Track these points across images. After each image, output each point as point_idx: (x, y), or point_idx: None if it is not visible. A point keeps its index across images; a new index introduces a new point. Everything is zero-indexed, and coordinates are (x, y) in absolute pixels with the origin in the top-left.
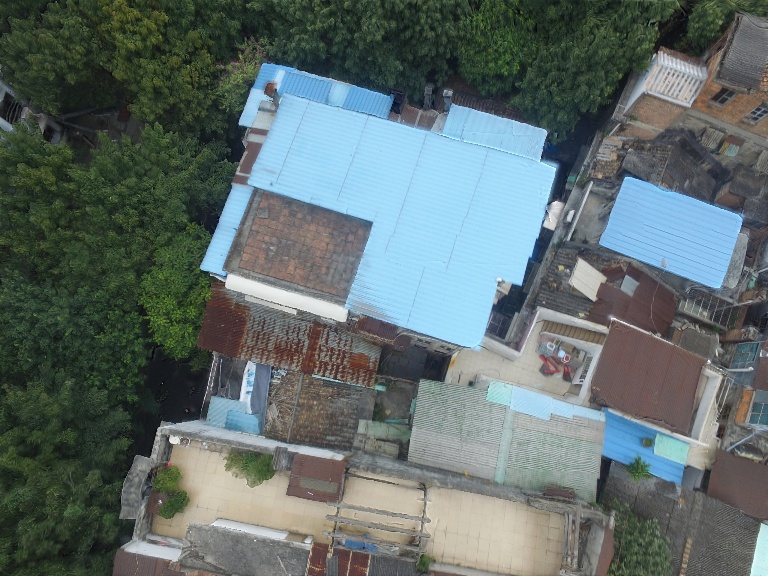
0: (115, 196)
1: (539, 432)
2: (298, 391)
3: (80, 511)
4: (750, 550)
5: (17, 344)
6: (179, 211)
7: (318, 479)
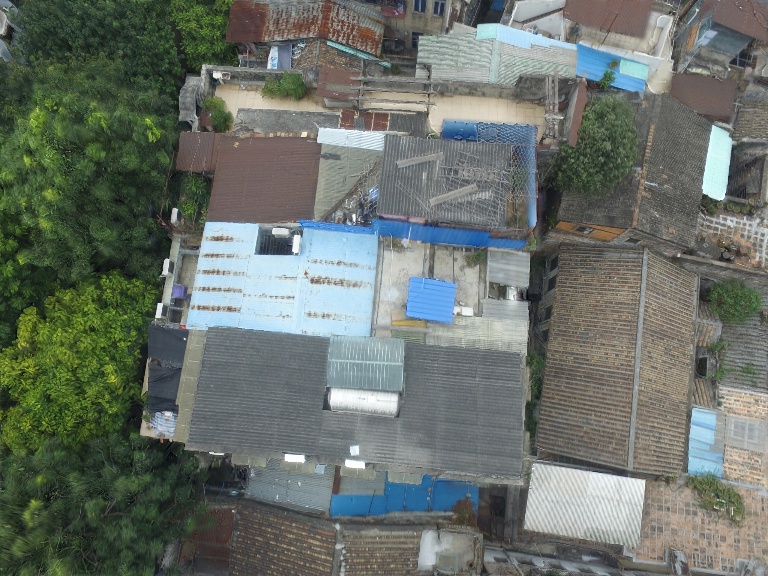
0: None
1: (522, 58)
2: (317, 54)
3: (148, 100)
4: (704, 143)
5: (71, 42)
6: None
7: (341, 85)
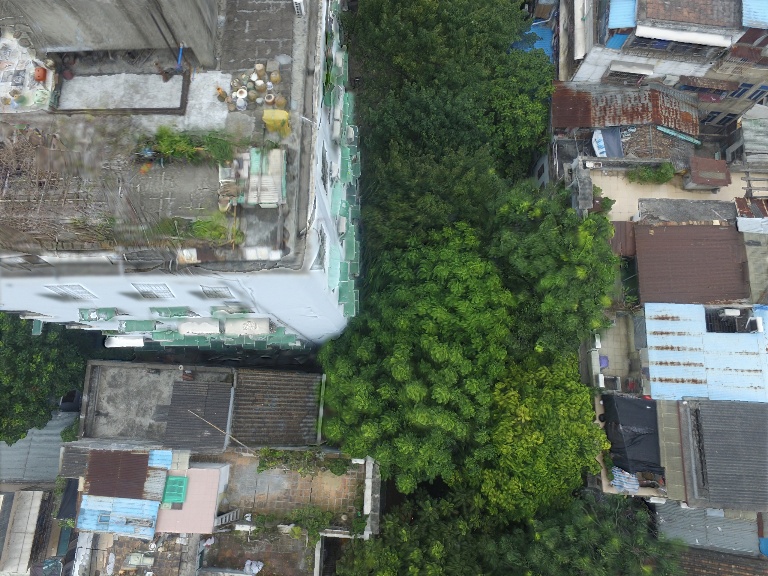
0: (475, 20)
1: None
2: (651, 138)
3: None
4: None
5: (425, 133)
6: (513, 34)
7: (710, 172)
